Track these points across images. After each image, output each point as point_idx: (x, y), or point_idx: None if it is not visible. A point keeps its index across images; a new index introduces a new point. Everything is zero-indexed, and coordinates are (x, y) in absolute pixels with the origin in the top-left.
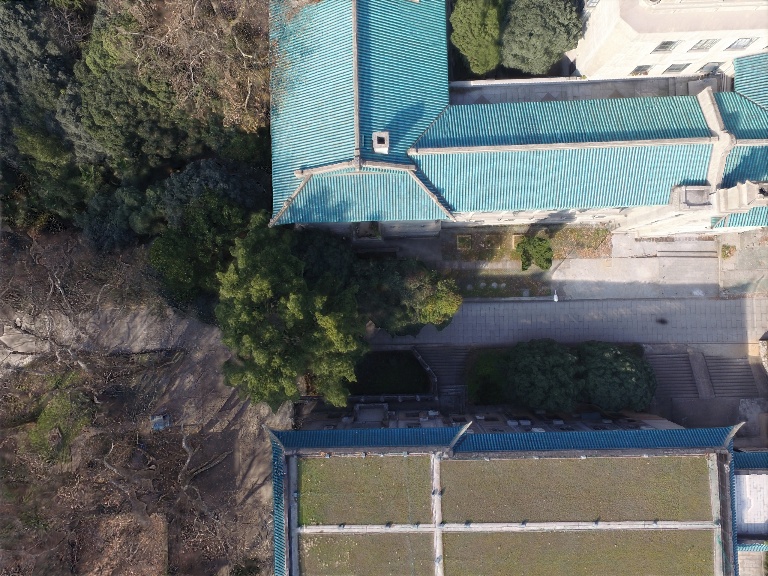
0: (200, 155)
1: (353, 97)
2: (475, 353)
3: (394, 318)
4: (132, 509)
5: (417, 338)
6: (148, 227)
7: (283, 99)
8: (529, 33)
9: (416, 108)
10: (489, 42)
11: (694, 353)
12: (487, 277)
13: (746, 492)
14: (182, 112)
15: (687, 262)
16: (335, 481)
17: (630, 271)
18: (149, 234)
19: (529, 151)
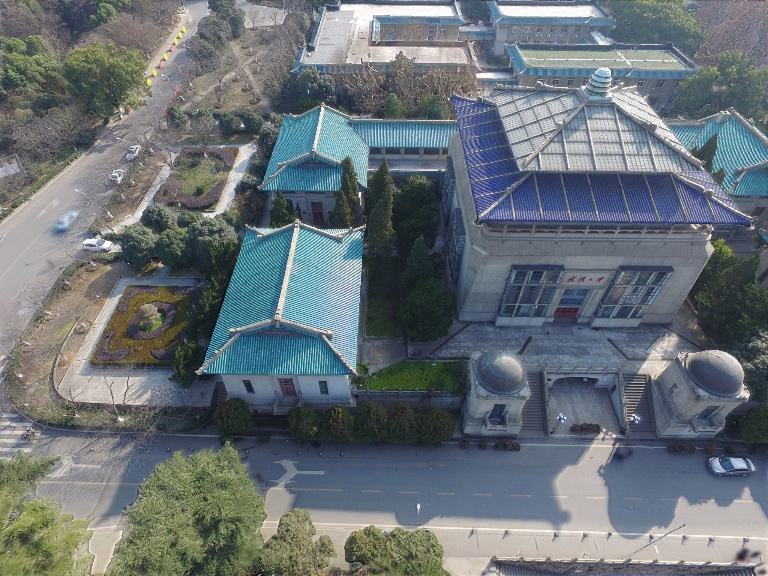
0: None
1: None
2: None
3: None
4: (763, 13)
5: None
6: None
7: None
8: None
9: None
10: None
11: None
12: None
13: None
14: None
15: None
16: None
17: None
18: None
19: None
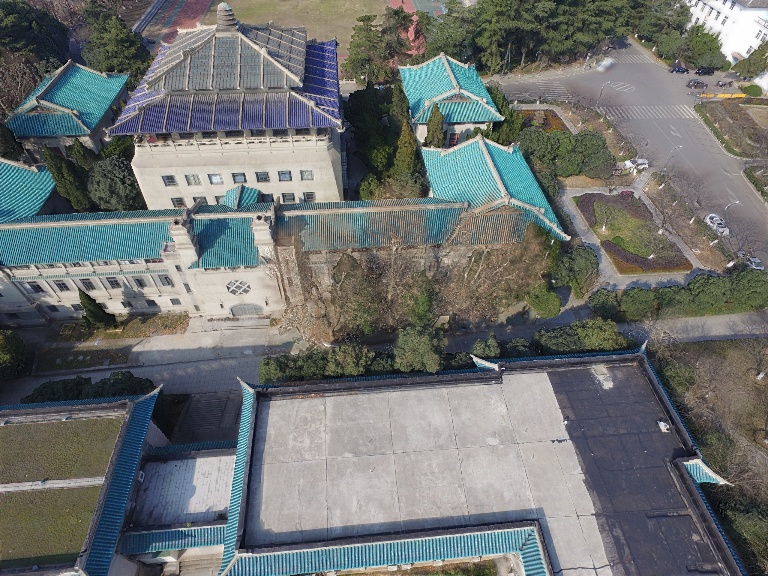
0: None
1: None
2: None
3: None
4: None
5: None
6: None
7: None
8: (97, 181)
9: (2, 212)
10: (70, 185)
11: (234, 397)
12: (76, 353)
13: (193, 479)
14: None
15: (244, 332)
16: None
17: (196, 341)
18: None
19: (63, 227)
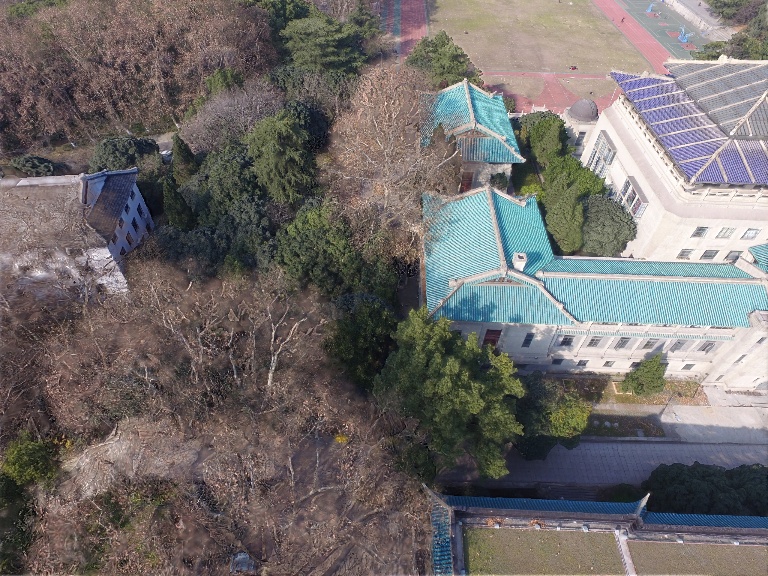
0: None
1: (495, 237)
2: (607, 489)
3: (531, 418)
4: (361, 445)
5: (539, 476)
6: None
7: (435, 247)
8: (603, 224)
9: (534, 254)
10: (577, 226)
11: None
12: (598, 416)
13: None
14: (351, 259)
15: None
16: (508, 559)
17: (734, 417)
18: None
19: (627, 281)
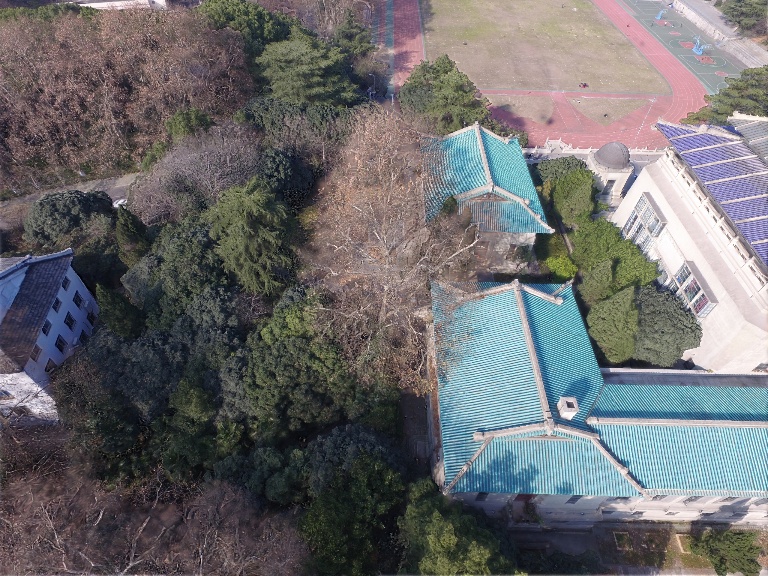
0: (334, 424)
1: (531, 367)
2: None
3: None
4: None
5: None
6: (284, 493)
7: (451, 369)
8: (661, 331)
9: (581, 383)
10: (630, 335)
11: None
12: None
13: None
14: (342, 378)
15: None
16: None
17: None
18: (280, 503)
19: (706, 427)
